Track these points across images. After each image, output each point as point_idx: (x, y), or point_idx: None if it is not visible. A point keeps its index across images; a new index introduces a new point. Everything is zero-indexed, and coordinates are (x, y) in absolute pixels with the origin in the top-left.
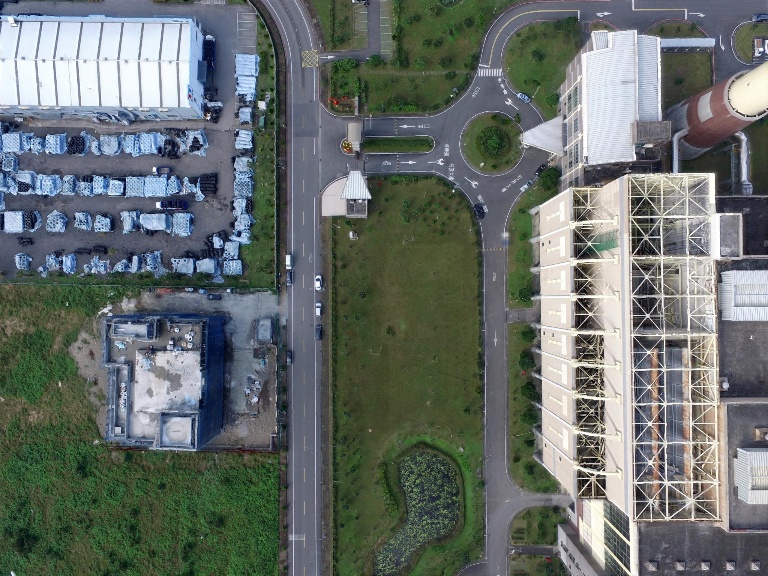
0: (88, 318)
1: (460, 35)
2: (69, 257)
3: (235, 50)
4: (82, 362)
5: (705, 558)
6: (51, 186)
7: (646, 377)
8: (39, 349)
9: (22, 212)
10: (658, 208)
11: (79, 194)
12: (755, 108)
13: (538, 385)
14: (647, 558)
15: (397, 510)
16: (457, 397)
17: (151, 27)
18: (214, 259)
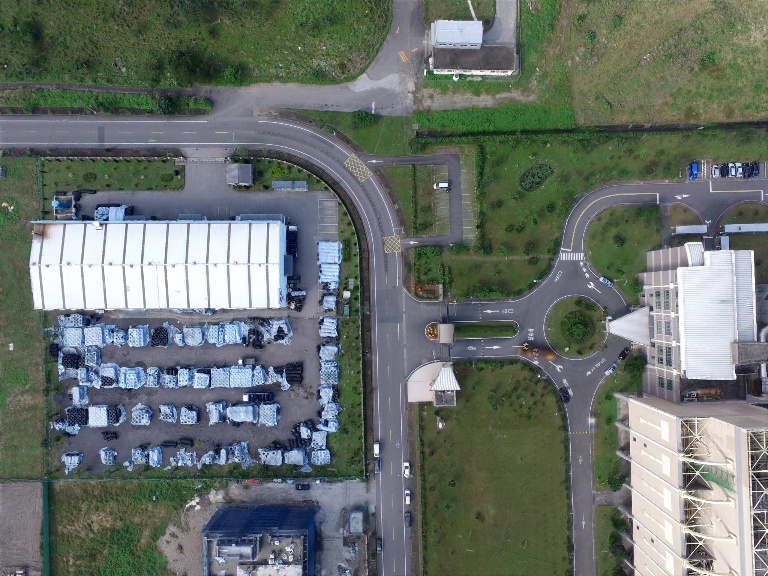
0: (176, 511)
1: (542, 220)
2: (155, 451)
3: (317, 237)
4: (171, 556)
5: None
6: (135, 380)
7: None
8: (127, 544)
9: (106, 406)
10: None
11: (163, 386)
12: None
13: (627, 567)
14: None
15: None
16: None
17: (238, 227)
18: (302, 449)
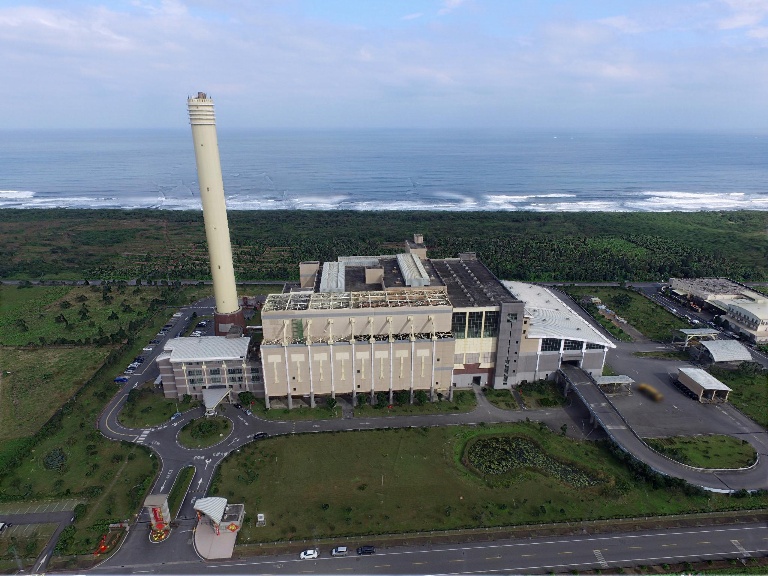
0: None
1: (98, 454)
2: None
3: None
4: None
5: None
6: None
7: None
8: None
9: None
10: None
11: None
12: (236, 304)
13: None
14: None
15: None
16: (416, 442)
17: None
18: None
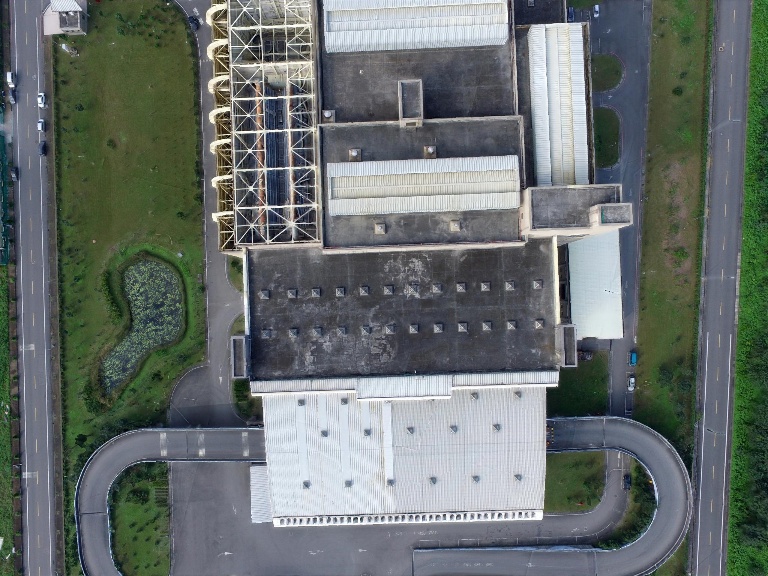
0: None
1: None
2: None
3: None
4: None
5: (316, 286)
6: None
7: (249, 108)
8: None
9: None
10: None
11: None
12: None
13: None
14: (260, 288)
15: (120, 316)
16: (177, 206)
17: None
18: None
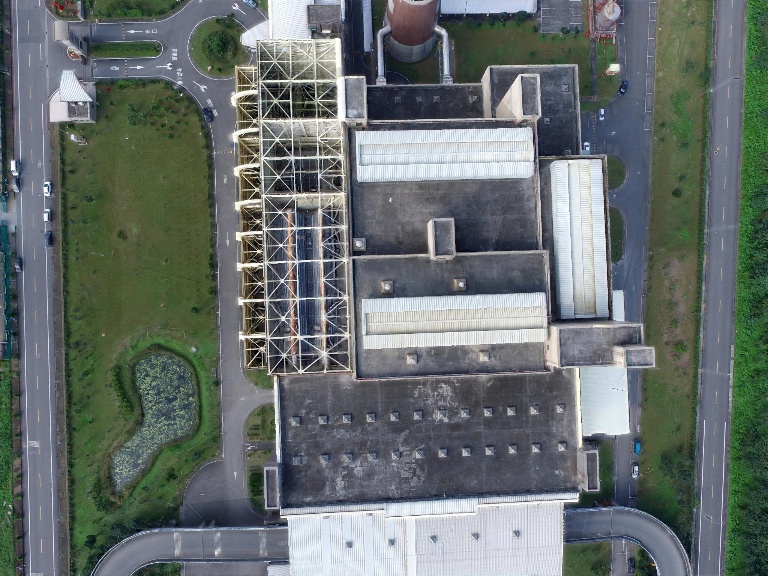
0: None
1: None
2: None
3: None
4: None
5: (347, 412)
6: None
7: (281, 237)
8: None
9: None
10: (287, 73)
11: None
12: None
13: None
14: (291, 414)
15: (131, 412)
16: (190, 299)
17: None
18: None
